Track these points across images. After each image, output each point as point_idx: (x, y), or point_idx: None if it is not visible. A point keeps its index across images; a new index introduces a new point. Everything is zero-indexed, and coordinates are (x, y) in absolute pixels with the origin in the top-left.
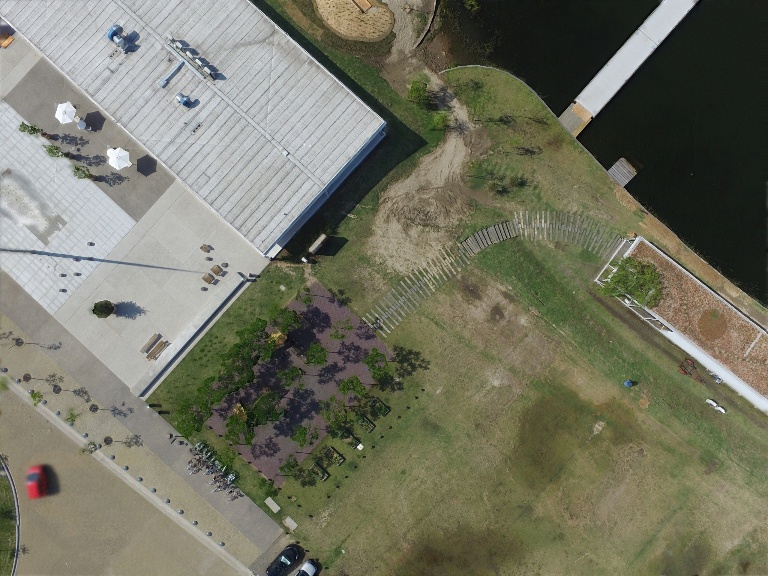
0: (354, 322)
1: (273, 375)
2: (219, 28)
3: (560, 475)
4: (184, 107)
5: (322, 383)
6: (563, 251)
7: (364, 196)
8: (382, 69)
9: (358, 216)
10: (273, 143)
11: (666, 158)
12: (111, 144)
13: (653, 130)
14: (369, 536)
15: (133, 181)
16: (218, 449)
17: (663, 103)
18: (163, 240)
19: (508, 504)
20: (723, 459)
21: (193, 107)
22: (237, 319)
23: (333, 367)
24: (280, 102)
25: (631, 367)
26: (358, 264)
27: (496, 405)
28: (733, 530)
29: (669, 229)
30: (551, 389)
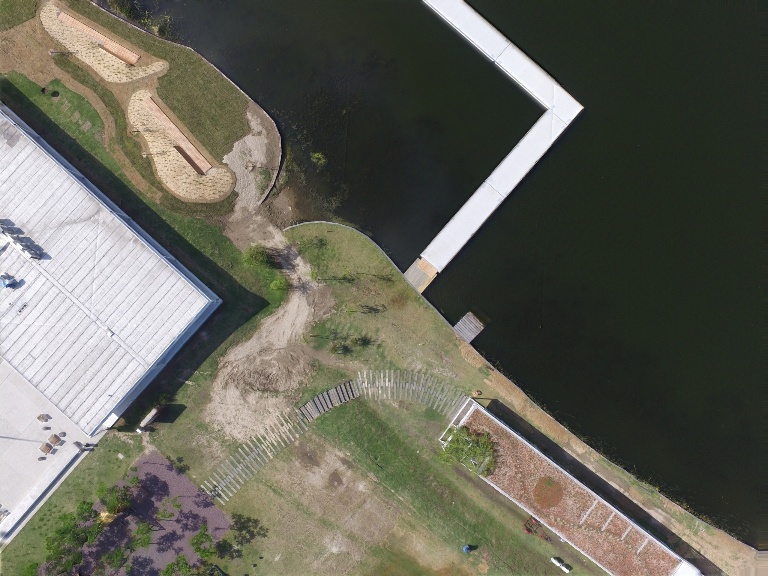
0: (192, 490)
1: (112, 544)
2: (44, 206)
3: None
4: (9, 288)
5: (161, 551)
6: (407, 410)
7: (202, 363)
8: (226, 227)
9: (196, 383)
10: (98, 323)
11: (514, 311)
12: None
13: (502, 282)
14: None
15: None
16: None
17: (511, 255)
18: (2, 409)
19: None
20: None
21: (18, 287)
22: (76, 488)
23: (172, 535)
24: (105, 281)
25: (472, 530)
26: (196, 431)
27: (334, 572)
28: None
29: (515, 385)
30: (390, 555)
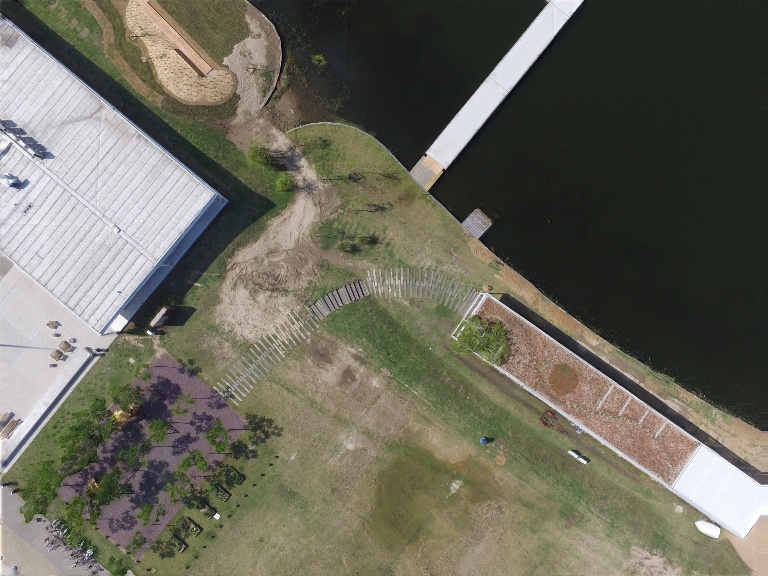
0: (205, 392)
1: (126, 448)
2: (45, 106)
3: (418, 536)
4: (13, 188)
5: (176, 454)
6: (418, 307)
7: (210, 264)
8: (228, 131)
9: (205, 284)
10: (104, 220)
11: (522, 206)
12: None
13: (508, 178)
14: None
15: None
16: None
17: (517, 150)
18: (10, 318)
19: (367, 567)
20: (583, 512)
21: (23, 188)
22: (88, 394)
23: (186, 438)
24: (109, 178)
25: (488, 423)
26: (207, 333)
27: (351, 468)
28: None
29: (526, 279)
30: (406, 450)
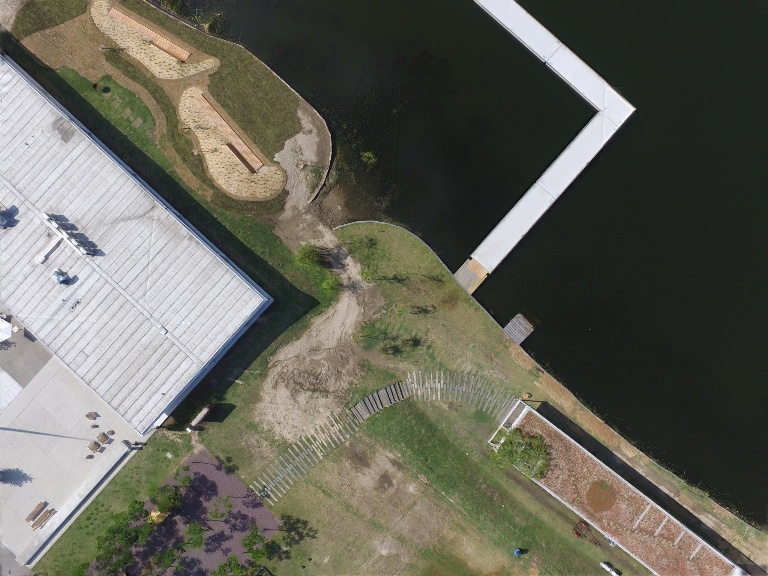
0: (241, 490)
1: (159, 544)
2: (99, 203)
3: None
4: (62, 284)
5: (209, 552)
6: (457, 412)
7: (252, 362)
8: (275, 226)
9: (246, 382)
10: (152, 321)
11: (564, 313)
12: None
13: (551, 284)
14: None
15: (20, 346)
16: None
17: (561, 257)
18: (49, 407)
19: None
20: None
21: (72, 284)
22: (123, 487)
23: (220, 536)
24: (159, 279)
25: (522, 533)
26: (246, 431)
27: (384, 574)
28: None
29: (565, 388)
30: (440, 558)
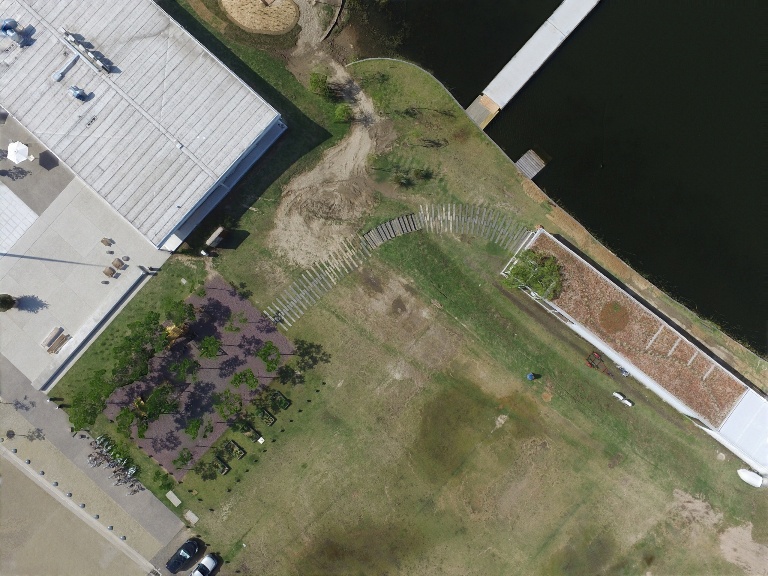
0: (255, 315)
1: None
2: (114, 21)
3: (462, 469)
4: (79, 100)
5: (223, 376)
6: (469, 244)
7: (266, 189)
8: (288, 62)
9: (260, 209)
10: (167, 136)
11: (575, 150)
12: (14, 138)
13: (562, 122)
14: (270, 530)
15: (35, 175)
16: (119, 443)
17: (572, 95)
18: (65, 234)
19: (409, 498)
20: (627, 452)
21: (88, 100)
22: (138, 313)
23: (234, 360)
24: (174, 95)
25: (535, 360)
26: (259, 257)
27: (397, 398)
28: (637, 524)
29: (577, 221)
30: (453, 382)
